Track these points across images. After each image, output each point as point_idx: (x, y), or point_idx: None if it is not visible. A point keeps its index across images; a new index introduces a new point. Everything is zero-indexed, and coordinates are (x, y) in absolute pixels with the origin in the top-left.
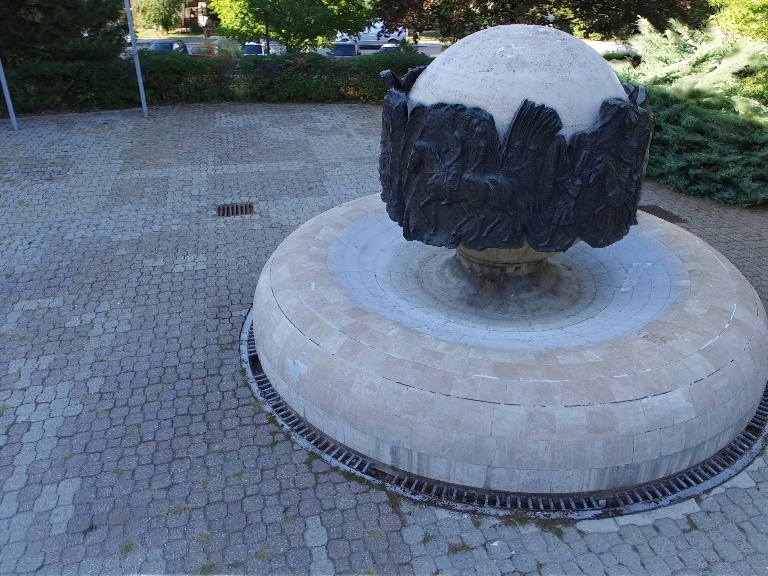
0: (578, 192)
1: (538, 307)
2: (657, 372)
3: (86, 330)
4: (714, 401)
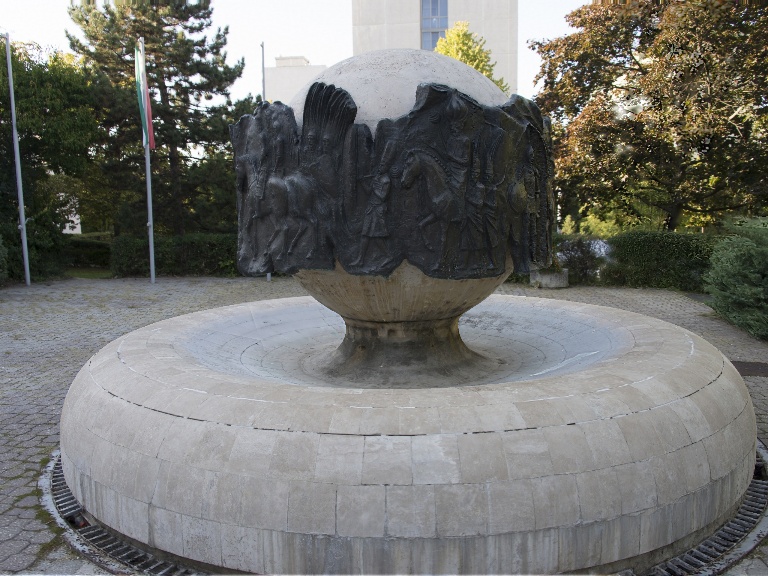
0: (385, 192)
1: (406, 381)
2: (419, 410)
3: (4, 386)
4: (504, 468)
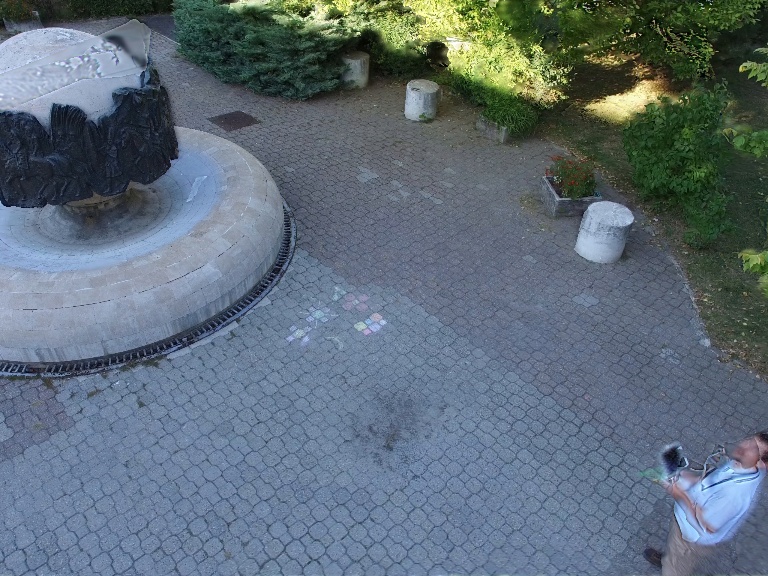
0: (116, 154)
1: (129, 228)
2: (195, 256)
3: None
4: (233, 264)
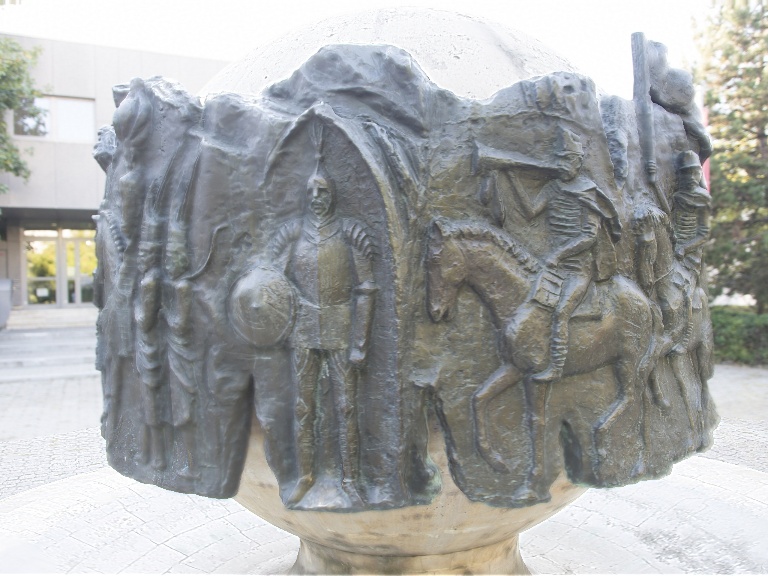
0: (94, 292)
1: None
2: None
3: None
4: None
